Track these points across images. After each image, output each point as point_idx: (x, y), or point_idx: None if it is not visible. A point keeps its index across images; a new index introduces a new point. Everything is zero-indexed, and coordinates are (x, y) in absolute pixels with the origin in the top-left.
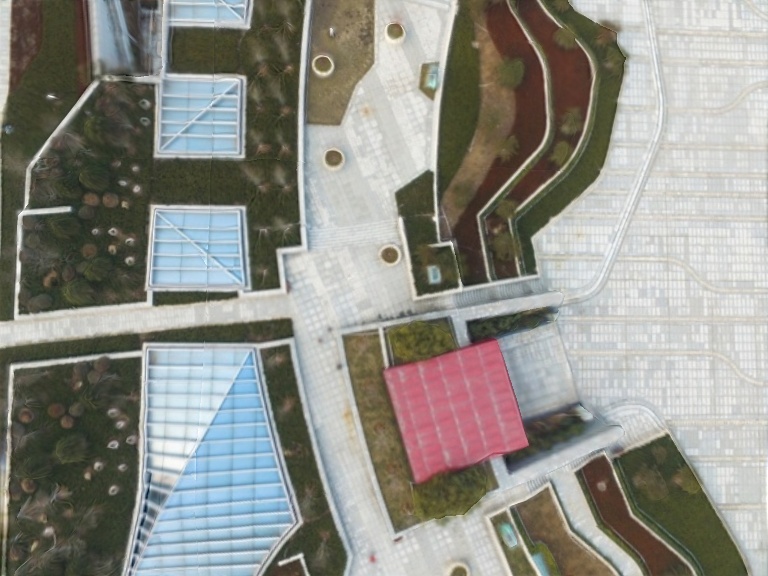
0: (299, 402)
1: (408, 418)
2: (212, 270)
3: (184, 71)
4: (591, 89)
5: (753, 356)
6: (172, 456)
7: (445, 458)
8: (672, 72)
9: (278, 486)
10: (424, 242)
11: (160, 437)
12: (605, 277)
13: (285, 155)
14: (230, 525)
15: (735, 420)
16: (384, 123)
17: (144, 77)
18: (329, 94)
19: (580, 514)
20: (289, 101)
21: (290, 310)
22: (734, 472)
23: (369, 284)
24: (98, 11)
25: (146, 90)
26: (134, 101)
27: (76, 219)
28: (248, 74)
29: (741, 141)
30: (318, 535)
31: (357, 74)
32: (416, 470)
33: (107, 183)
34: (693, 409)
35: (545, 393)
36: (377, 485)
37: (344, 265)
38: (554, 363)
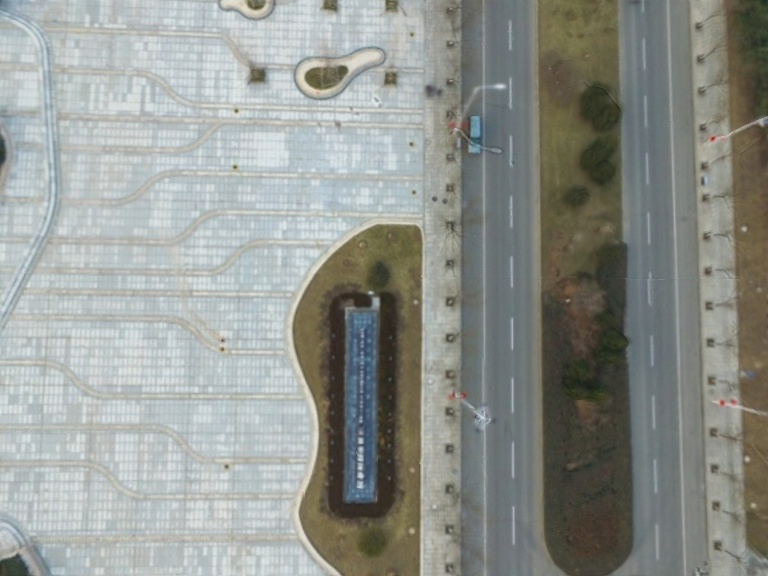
0: None
1: None
2: None
3: None
4: None
5: (135, 467)
6: None
7: None
8: (70, 160)
9: None
10: None
11: None
12: None
13: None
14: None
15: (109, 536)
16: None
17: None
18: None
19: None
20: None
21: None
22: None
23: None
24: None
25: None
26: None
27: None
28: None
29: (140, 235)
30: None
31: None
32: None
33: None
34: (62, 524)
35: None
36: None
37: None
38: None
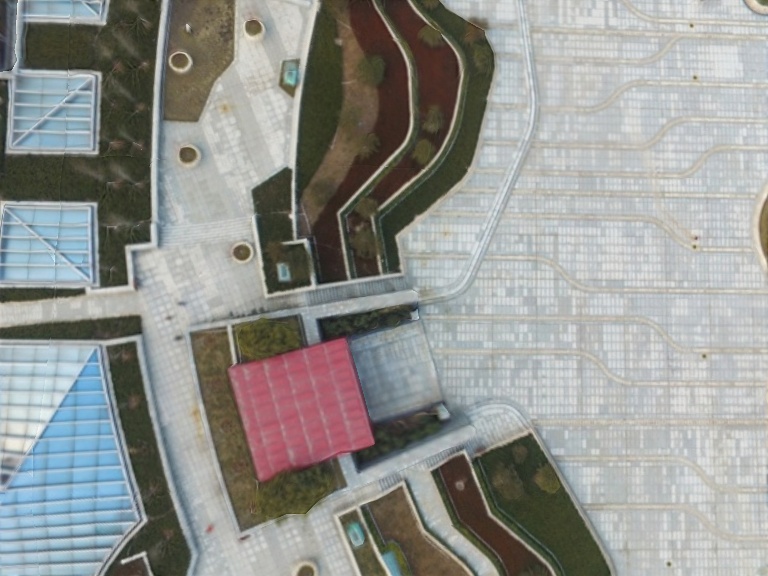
0: (145, 399)
1: (252, 416)
2: (60, 267)
3: (38, 67)
4: (459, 87)
5: (622, 356)
6: (11, 453)
7: (289, 456)
8: (545, 70)
9: (121, 484)
10: (278, 239)
11: (2, 434)
12: (472, 276)
13: (138, 152)
14: (70, 523)
15: (602, 420)
16: (243, 120)
17: None
18: (187, 91)
19: (435, 513)
20: (144, 97)
21: (139, 307)
22: (600, 472)
23: (221, 281)
24: None
25: None
26: None
27: None
28: (103, 70)
29: (614, 140)
30: (162, 533)
31: (216, 71)
32: (260, 468)
33: None
34: (559, 408)
35: (409, 392)
36: (223, 483)
37: (196, 262)
38: (418, 362)
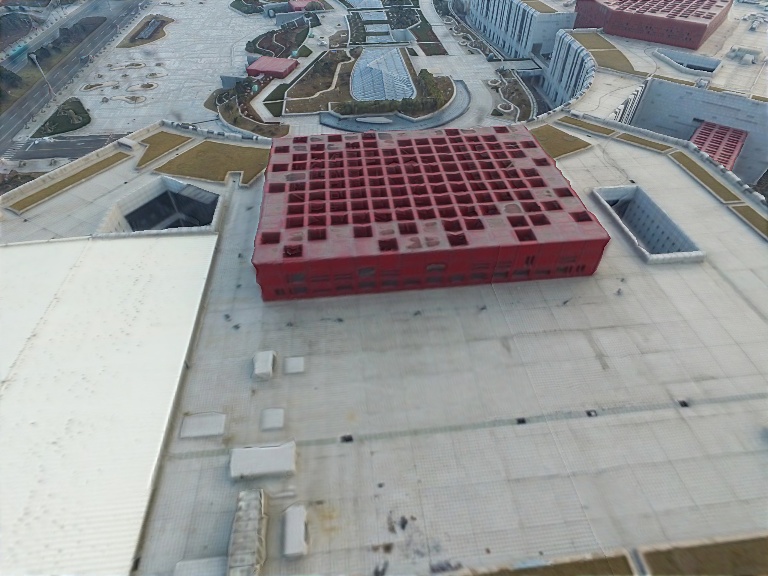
0: None
1: None
2: None
3: None
4: None
5: None
6: None
7: None
8: None
9: None
10: None
11: (376, 1)
12: None
13: None
14: None
15: None
16: None
17: (395, 30)
18: None
19: None
20: None
21: None
22: (229, 14)
23: None
24: None
25: None
26: None
27: None
28: None
29: None
30: None
31: None
32: None
33: None
34: None
35: None
36: None
37: None
38: None
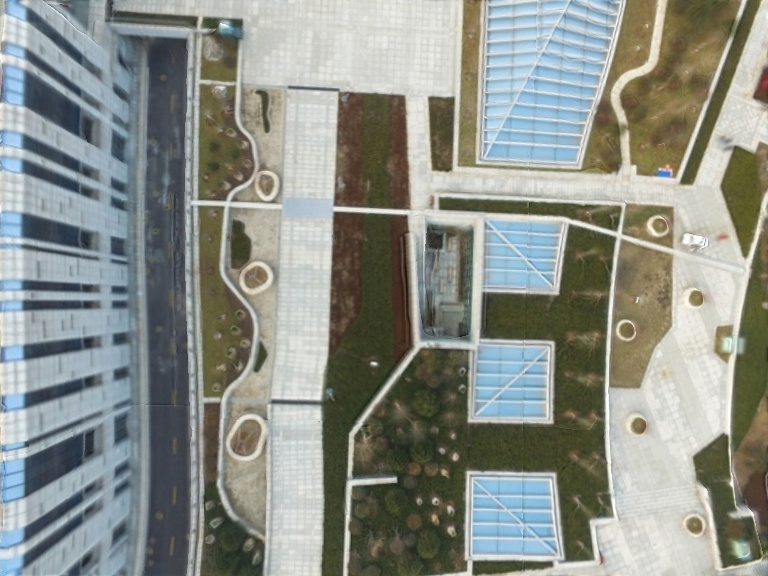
0: None
1: None
2: (528, 540)
3: (496, 336)
4: None
5: None
6: None
7: None
8: None
9: None
10: (725, 510)
11: None
12: None
13: (594, 423)
14: None
15: None
16: (681, 386)
17: (460, 343)
18: (630, 357)
19: None
20: (596, 368)
21: None
22: None
23: (674, 553)
24: (416, 277)
25: (462, 356)
26: (454, 371)
27: (403, 490)
28: (557, 340)
29: None
30: None
31: (656, 337)
32: None
33: (431, 454)
34: None
35: None
36: None
37: (650, 534)
38: None
